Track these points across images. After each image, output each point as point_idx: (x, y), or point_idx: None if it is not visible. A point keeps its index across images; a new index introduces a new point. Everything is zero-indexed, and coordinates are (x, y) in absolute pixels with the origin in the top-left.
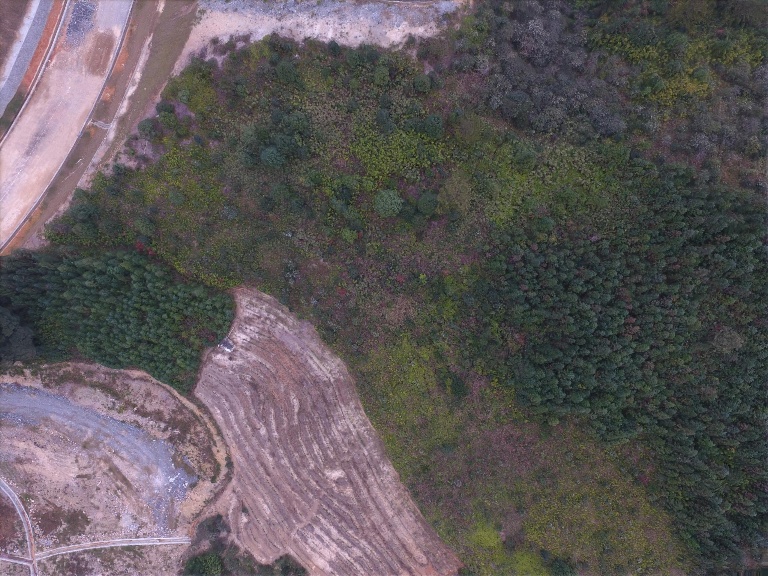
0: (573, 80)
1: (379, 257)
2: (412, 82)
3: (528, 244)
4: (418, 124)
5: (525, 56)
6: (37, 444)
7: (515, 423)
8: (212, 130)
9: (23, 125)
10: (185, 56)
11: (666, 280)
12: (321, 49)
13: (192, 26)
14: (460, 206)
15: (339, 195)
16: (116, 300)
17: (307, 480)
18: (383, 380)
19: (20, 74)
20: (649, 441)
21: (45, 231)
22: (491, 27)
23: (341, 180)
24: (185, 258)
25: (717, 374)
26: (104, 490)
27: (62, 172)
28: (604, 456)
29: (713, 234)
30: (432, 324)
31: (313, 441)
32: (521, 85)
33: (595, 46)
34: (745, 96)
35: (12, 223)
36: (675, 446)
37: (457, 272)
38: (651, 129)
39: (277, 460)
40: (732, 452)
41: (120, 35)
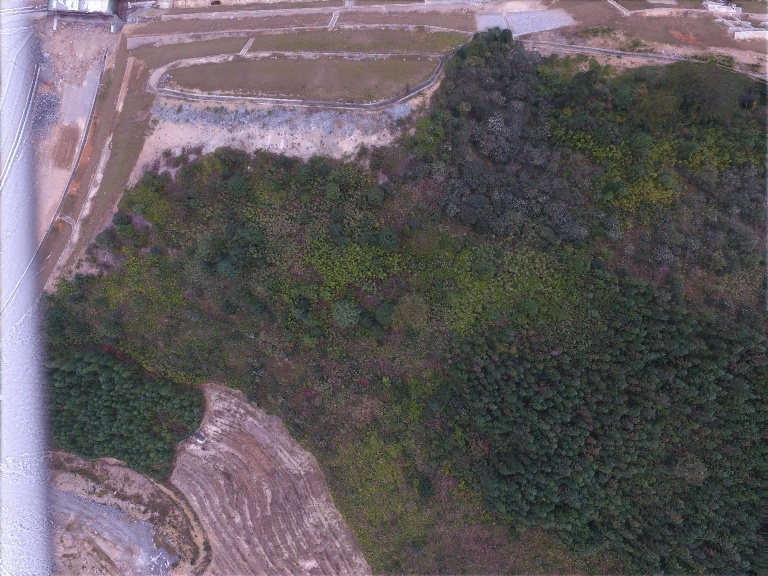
0: (535, 178)
1: (341, 361)
2: (365, 195)
3: (489, 354)
4: (372, 238)
5: (485, 155)
6: (23, 526)
7: (483, 525)
8: (169, 240)
9: None
10: (139, 168)
11: (628, 401)
12: (272, 162)
13: (145, 137)
14: (414, 325)
15: (297, 305)
16: (87, 398)
17: (282, 569)
18: (352, 475)
19: None
20: (617, 552)
21: (15, 333)
22: (448, 129)
23: (298, 290)
24: (152, 357)
25: (683, 496)
26: (90, 568)
27: (32, 268)
28: (573, 563)
29: (675, 357)
30: (398, 424)
31: (286, 532)
32: (480, 189)
33: (559, 140)
34: (712, 203)
35: None
36: (641, 564)
37: (420, 375)
38: (613, 238)
39: (252, 548)
40: (700, 573)
41: (85, 127)
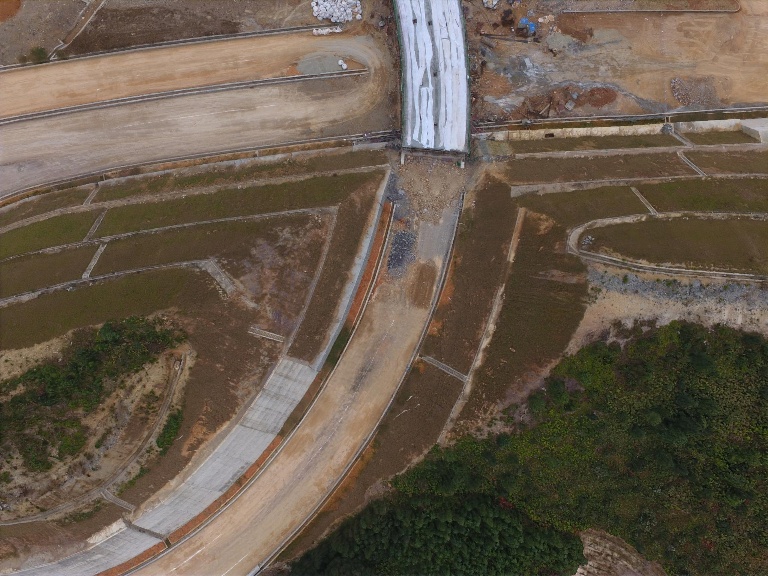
0: None
1: (761, 520)
2: None
3: None
4: None
5: None
6: None
7: None
8: (605, 406)
9: (348, 360)
10: (581, 336)
11: None
12: (736, 339)
13: (586, 305)
14: None
15: (738, 471)
16: None
17: None
18: None
19: (347, 311)
20: None
21: (399, 484)
22: None
23: (742, 458)
24: (539, 506)
25: None
26: None
27: (393, 409)
28: None
29: None
30: None
31: None
32: None
33: None
34: None
35: (342, 461)
36: None
37: None
38: None
39: None
40: None
41: (442, 266)
